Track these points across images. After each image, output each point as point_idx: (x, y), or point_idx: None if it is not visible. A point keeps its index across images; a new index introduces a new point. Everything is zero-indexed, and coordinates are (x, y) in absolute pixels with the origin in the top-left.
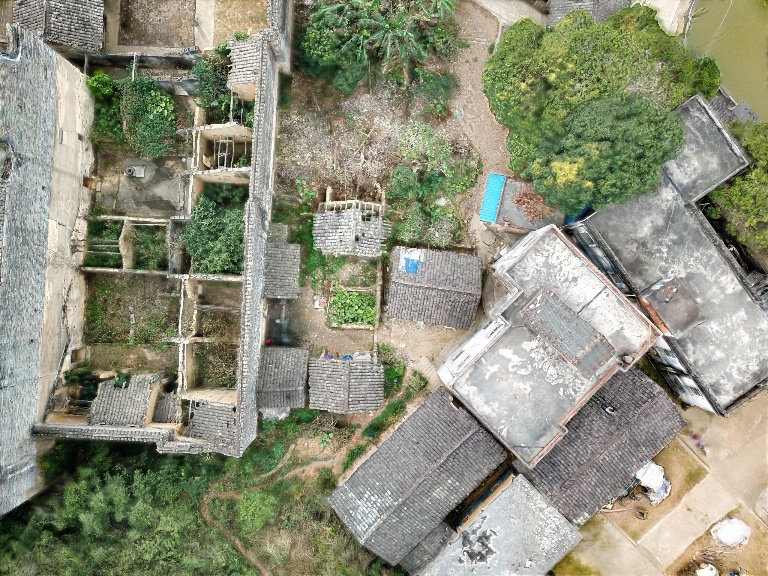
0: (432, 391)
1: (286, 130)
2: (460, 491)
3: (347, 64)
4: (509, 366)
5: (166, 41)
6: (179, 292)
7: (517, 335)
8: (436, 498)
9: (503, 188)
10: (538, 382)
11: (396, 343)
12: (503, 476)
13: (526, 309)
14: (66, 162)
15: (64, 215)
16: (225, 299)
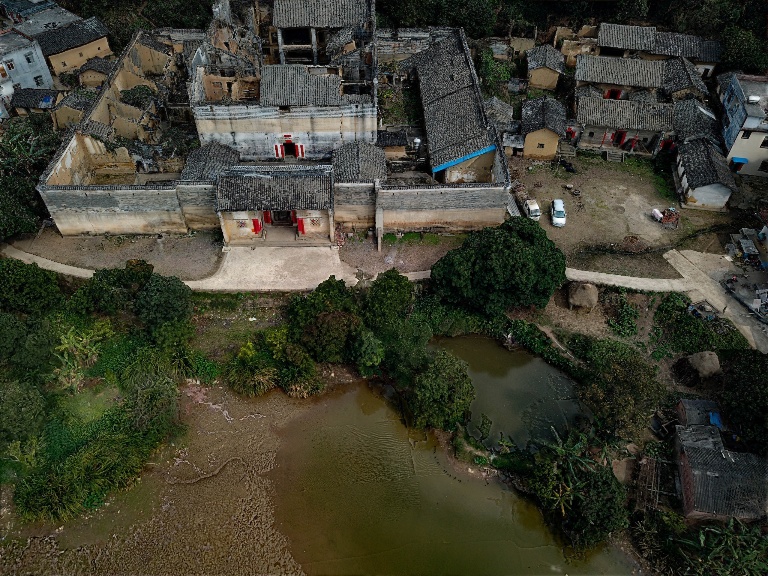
0: (59, 77)
1: None
2: None
3: None
4: (6, 48)
5: None
6: None
7: None
8: None
9: None
10: None
11: None
12: None
13: None
14: None
15: None
16: None
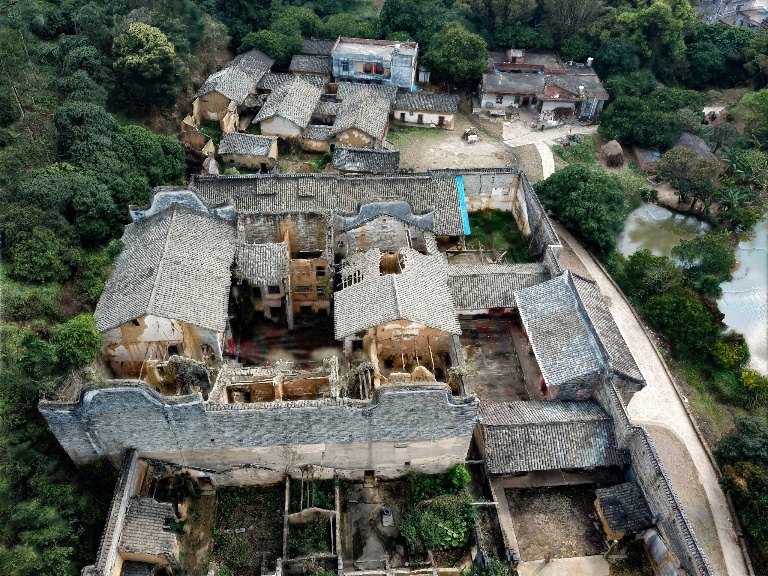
0: None
1: None
2: None
3: None
4: None
5: (521, 532)
6: None
7: None
8: None
9: None
10: None
11: None
12: None
13: None
14: (380, 453)
15: (333, 456)
16: None
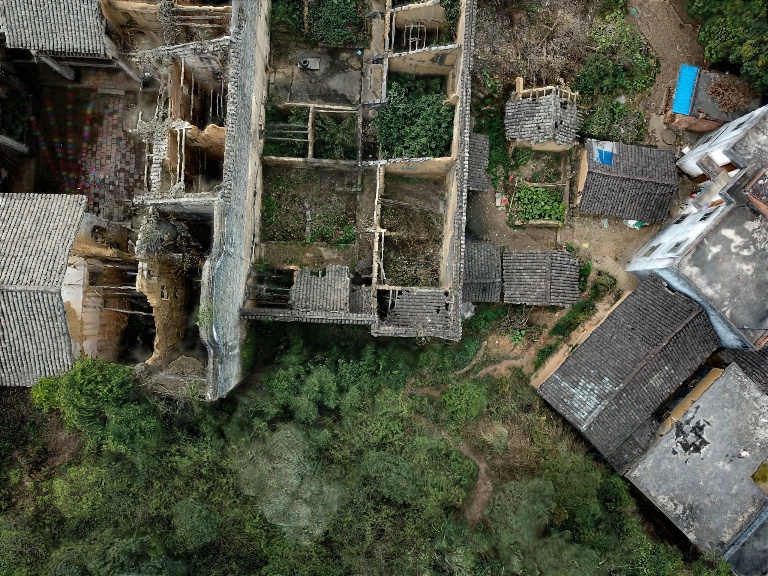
0: (622, 289)
1: None
2: (673, 380)
3: None
4: (731, 246)
5: None
6: (360, 186)
7: (739, 215)
8: (652, 386)
9: (697, 79)
10: (760, 263)
11: (579, 242)
12: (701, 372)
13: (755, 185)
14: (260, 39)
15: (258, 95)
16: (405, 196)
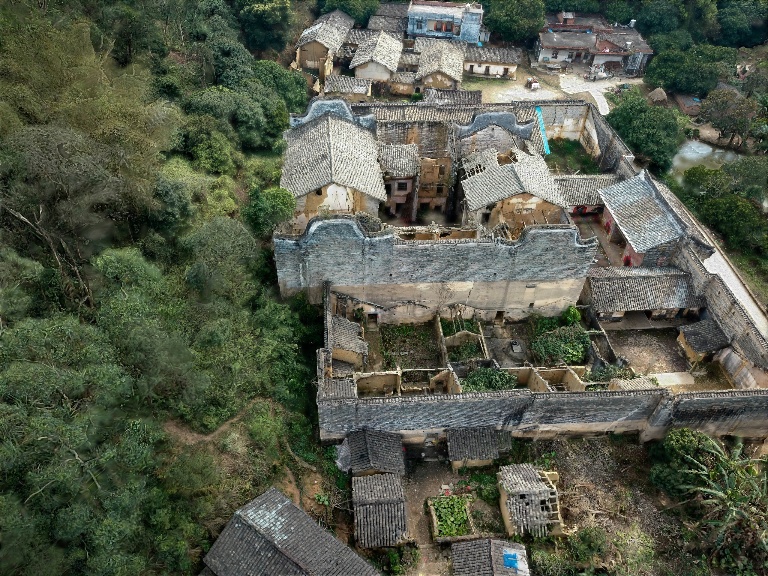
0: None
1: (592, 445)
2: None
3: (676, 466)
4: None
5: None
6: None
7: None
8: None
9: None
10: None
11: (423, 569)
12: None
13: None
14: (513, 293)
15: (476, 296)
16: None
